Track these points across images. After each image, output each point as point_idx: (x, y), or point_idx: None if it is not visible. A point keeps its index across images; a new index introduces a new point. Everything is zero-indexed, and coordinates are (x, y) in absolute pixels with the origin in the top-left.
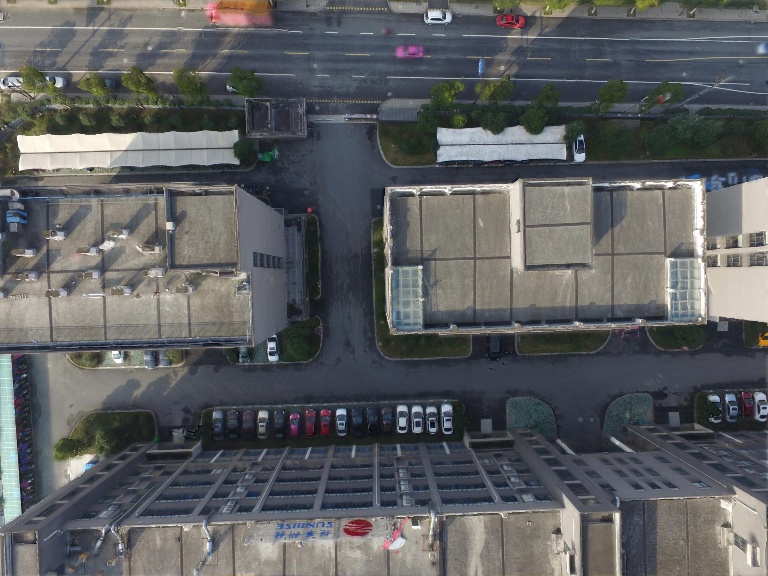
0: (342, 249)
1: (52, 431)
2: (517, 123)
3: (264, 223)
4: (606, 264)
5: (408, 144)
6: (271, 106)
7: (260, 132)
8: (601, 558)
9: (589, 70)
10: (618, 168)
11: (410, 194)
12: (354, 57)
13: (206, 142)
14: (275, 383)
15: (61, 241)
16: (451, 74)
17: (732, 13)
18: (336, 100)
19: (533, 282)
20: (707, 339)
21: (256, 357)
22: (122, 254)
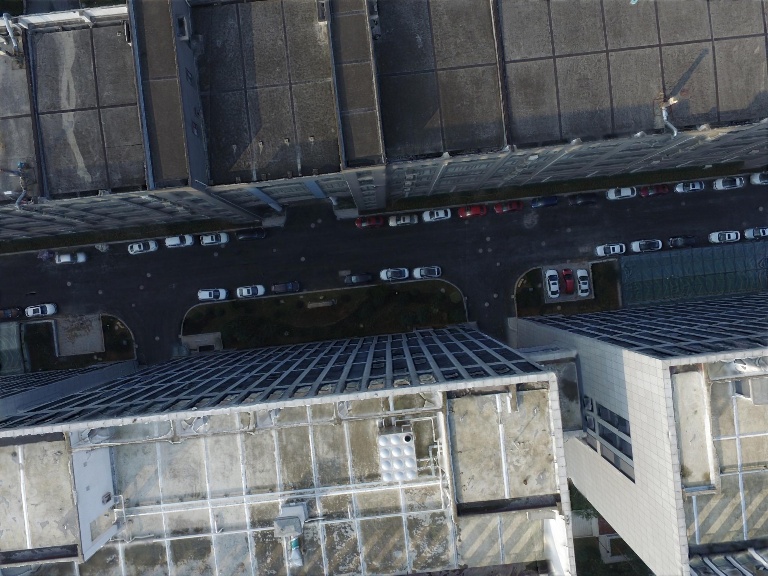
0: None
1: None
2: None
3: None
4: None
5: None
6: None
7: None
8: (157, 21)
9: None
10: None
11: None
12: None
13: None
14: None
15: None
16: None
17: None
18: None
19: None
20: None
21: None
22: None
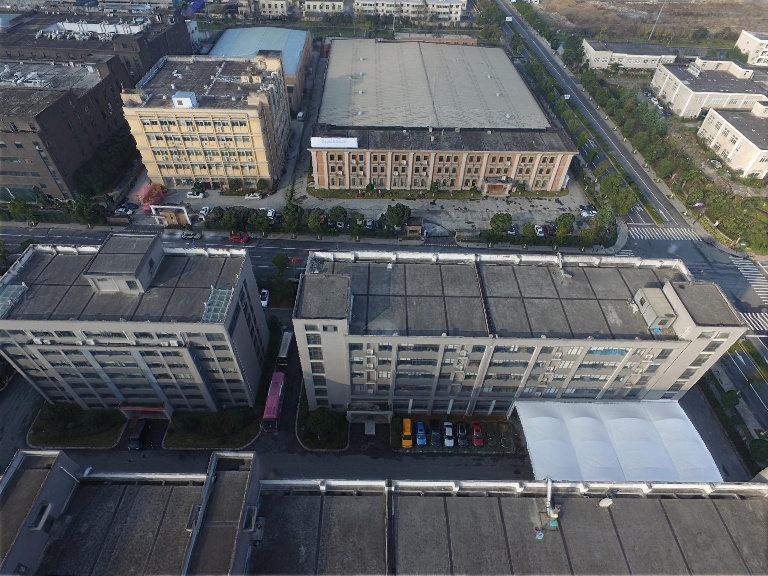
0: None
1: None
2: None
3: None
4: (168, 292)
5: None
6: None
7: None
8: (18, 507)
9: None
10: None
11: (51, 253)
12: None
13: None
14: None
15: None
16: None
17: (385, 241)
18: None
19: (107, 300)
20: (354, 441)
21: None
22: None
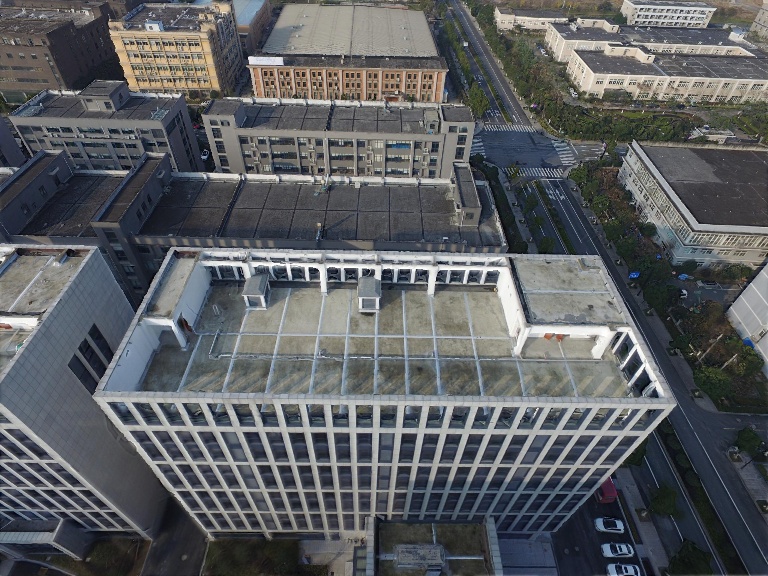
0: None
1: None
2: None
3: None
4: None
5: None
6: None
7: None
8: None
9: None
10: None
11: None
12: None
13: None
14: None
15: None
16: None
17: None
18: None
19: None
20: None
21: None
22: None
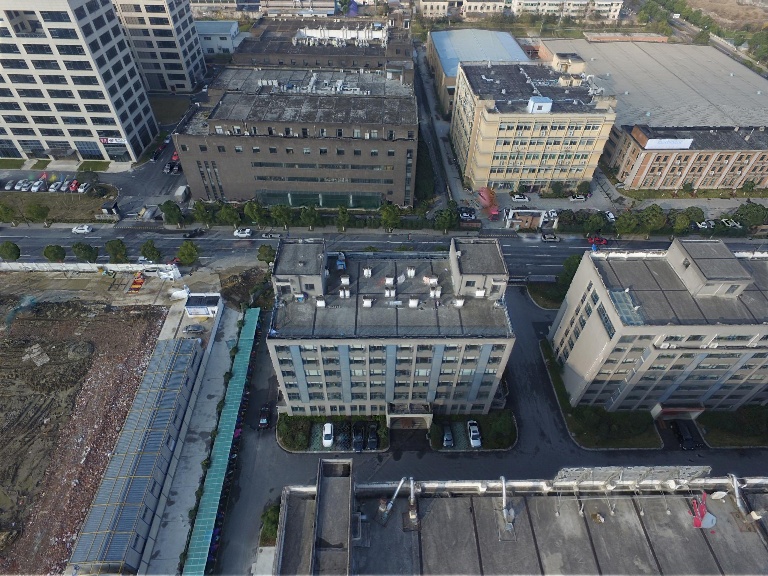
0: (519, 360)
1: (245, 518)
2: None
3: None
4: (759, 295)
5: (552, 296)
6: None
7: None
8: None
9: None
10: None
11: (600, 260)
12: None
13: None
14: (479, 470)
15: (368, 278)
16: None
17: (736, 240)
18: None
19: (712, 304)
20: None
21: (458, 444)
22: (410, 286)
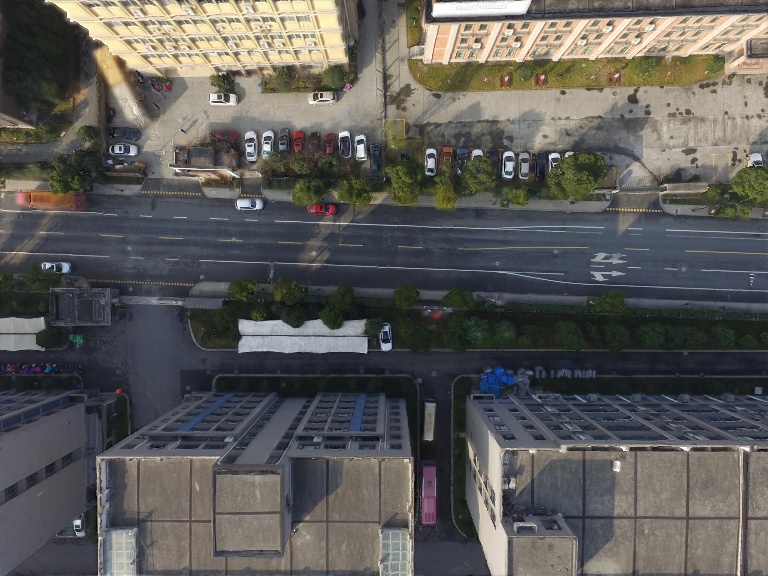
0: None
1: None
2: (317, 317)
3: (23, 448)
4: (320, 531)
5: (216, 329)
6: (74, 297)
7: (63, 322)
8: None
9: (401, 257)
10: (427, 356)
11: None
12: (168, 240)
13: (14, 328)
14: (84, 556)
15: None
16: (263, 258)
17: (547, 203)
18: (149, 282)
19: None
20: None
21: (65, 530)
22: None
